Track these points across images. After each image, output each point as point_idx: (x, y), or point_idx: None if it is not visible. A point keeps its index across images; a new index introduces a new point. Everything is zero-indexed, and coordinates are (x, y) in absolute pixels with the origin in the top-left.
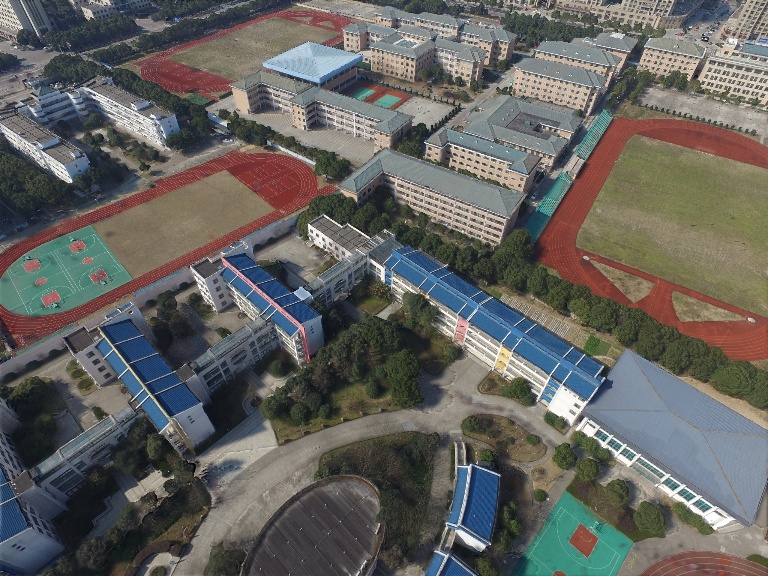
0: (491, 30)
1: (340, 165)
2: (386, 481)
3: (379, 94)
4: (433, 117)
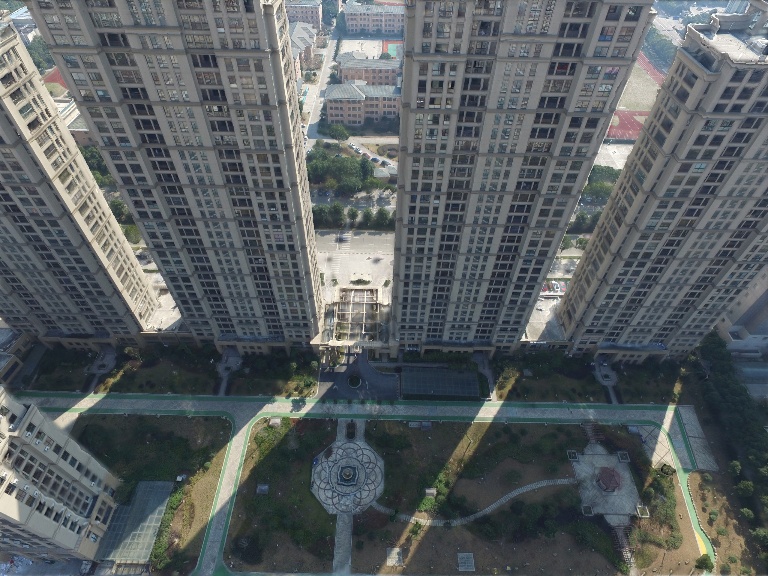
0: (357, 84)
1: None
2: None
3: None
4: (349, 49)
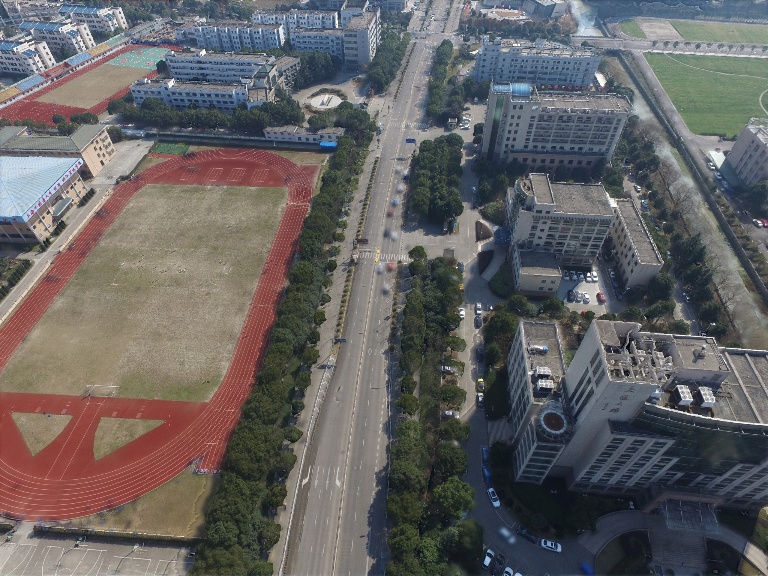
0: None
1: None
2: None
3: None
4: None
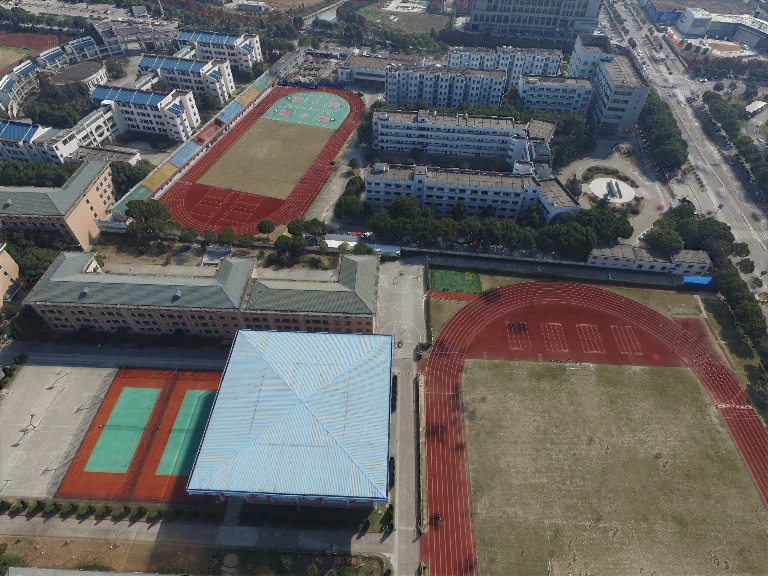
0: None
1: (128, 203)
2: (49, 90)
3: (145, 461)
4: (4, 426)
